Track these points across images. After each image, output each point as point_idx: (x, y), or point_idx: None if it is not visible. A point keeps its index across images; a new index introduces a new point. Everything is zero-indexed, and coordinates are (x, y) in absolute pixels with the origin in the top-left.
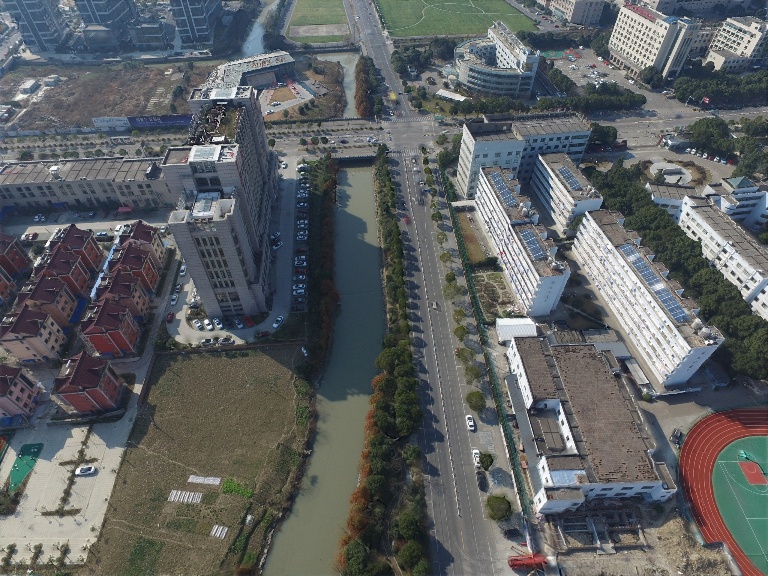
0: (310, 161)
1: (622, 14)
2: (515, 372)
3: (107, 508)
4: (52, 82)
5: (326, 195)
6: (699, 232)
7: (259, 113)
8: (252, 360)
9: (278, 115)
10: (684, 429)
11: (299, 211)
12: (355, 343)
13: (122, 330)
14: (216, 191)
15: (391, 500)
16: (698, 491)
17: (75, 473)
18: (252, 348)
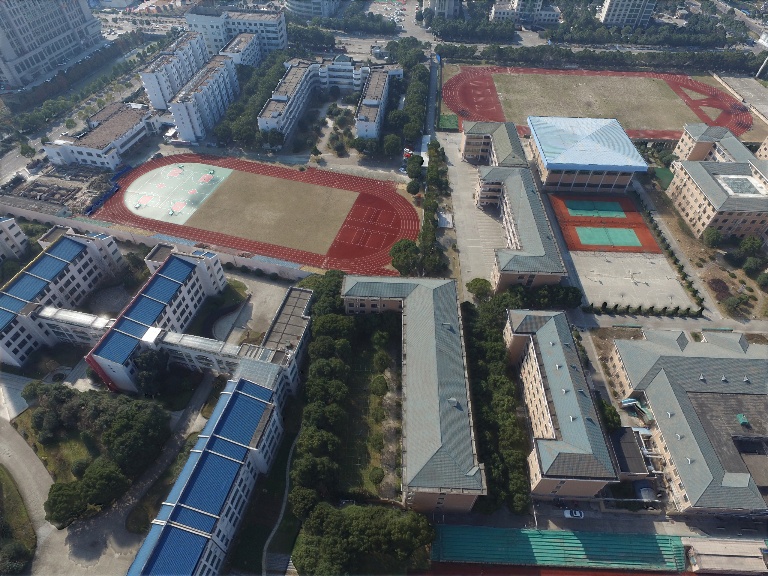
0: None
1: None
2: None
3: None
4: None
5: (112, 46)
6: None
7: None
8: None
9: (144, 11)
10: (166, 155)
11: (93, 52)
12: None
13: None
14: None
15: None
16: (138, 172)
17: None
18: None
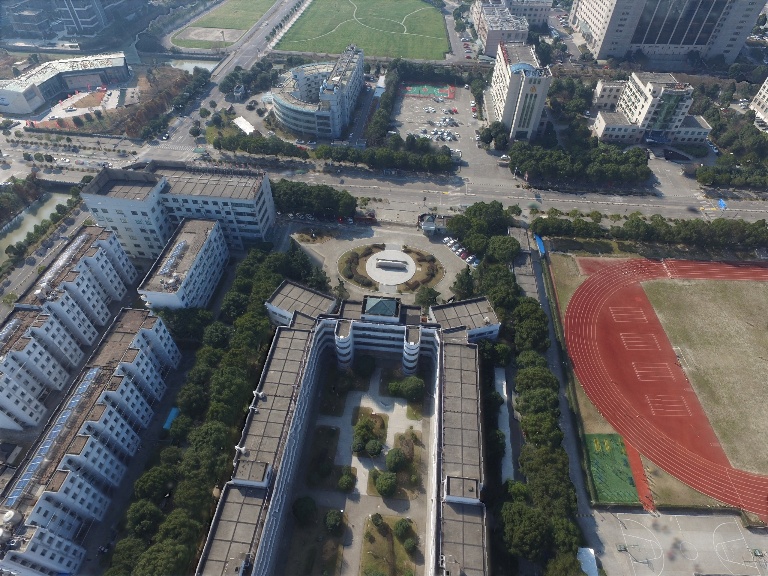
0: (20, 179)
1: (498, 52)
2: None
3: None
4: None
5: None
6: None
7: None
8: None
9: (55, 122)
10: None
11: None
12: None
13: None
14: None
15: None
16: None
17: None
18: None
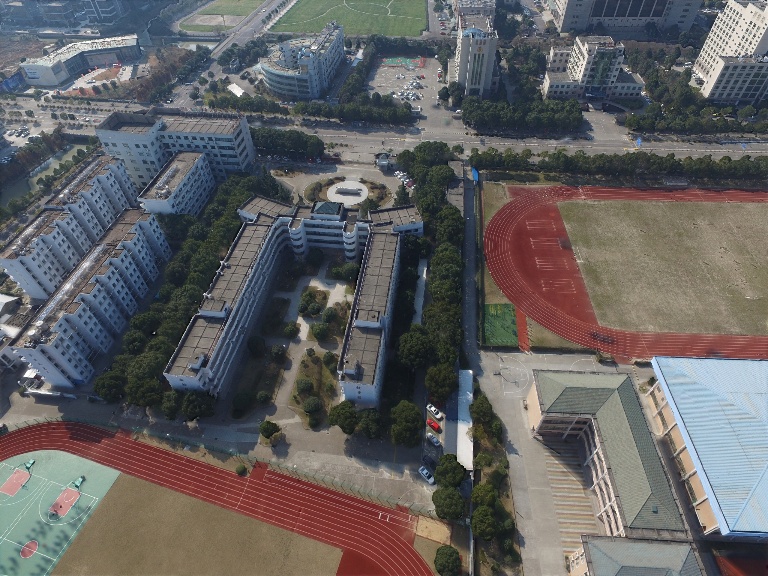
0: (49, 134)
1: None
2: None
3: None
4: None
5: (10, 163)
6: None
7: None
8: None
9: None
10: (15, 427)
11: None
12: None
13: None
14: None
15: None
16: None
17: None
18: None
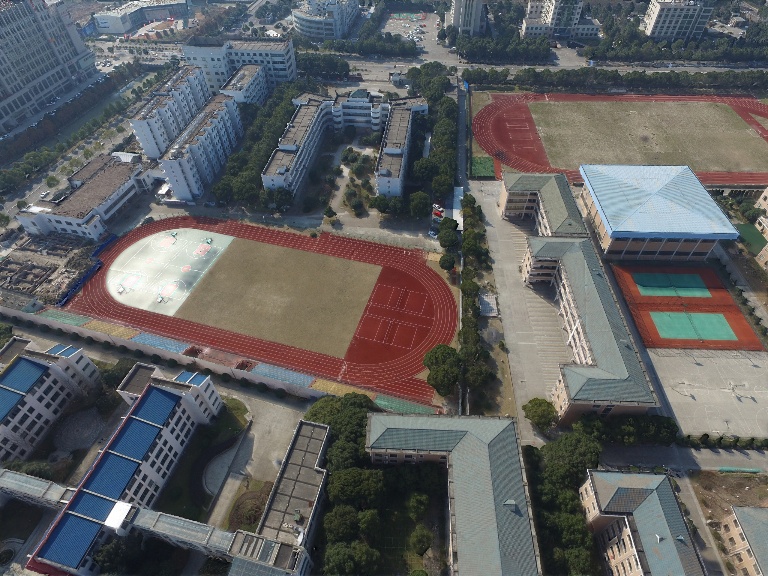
0: None
1: None
2: None
3: None
4: None
5: (106, 81)
6: None
7: (61, 15)
8: None
9: (143, 37)
10: (158, 218)
11: (85, 89)
12: None
13: None
14: None
15: None
16: (124, 242)
17: None
18: None
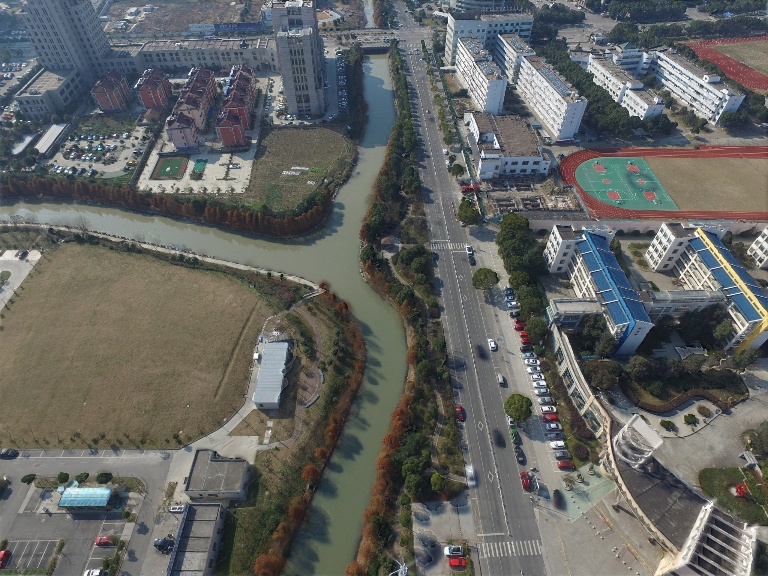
0: (344, 49)
1: None
2: (472, 131)
3: (250, 178)
4: (149, 9)
5: (357, 63)
6: (595, 72)
7: None
8: (319, 130)
9: None
10: (566, 154)
11: (339, 72)
12: (378, 130)
13: (244, 109)
14: (300, 27)
15: (401, 175)
16: (567, 173)
17: (229, 167)
18: (318, 126)
